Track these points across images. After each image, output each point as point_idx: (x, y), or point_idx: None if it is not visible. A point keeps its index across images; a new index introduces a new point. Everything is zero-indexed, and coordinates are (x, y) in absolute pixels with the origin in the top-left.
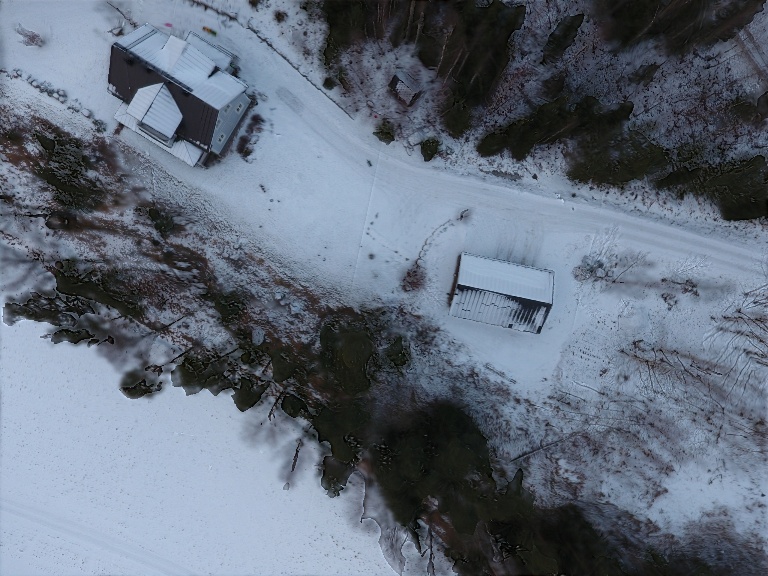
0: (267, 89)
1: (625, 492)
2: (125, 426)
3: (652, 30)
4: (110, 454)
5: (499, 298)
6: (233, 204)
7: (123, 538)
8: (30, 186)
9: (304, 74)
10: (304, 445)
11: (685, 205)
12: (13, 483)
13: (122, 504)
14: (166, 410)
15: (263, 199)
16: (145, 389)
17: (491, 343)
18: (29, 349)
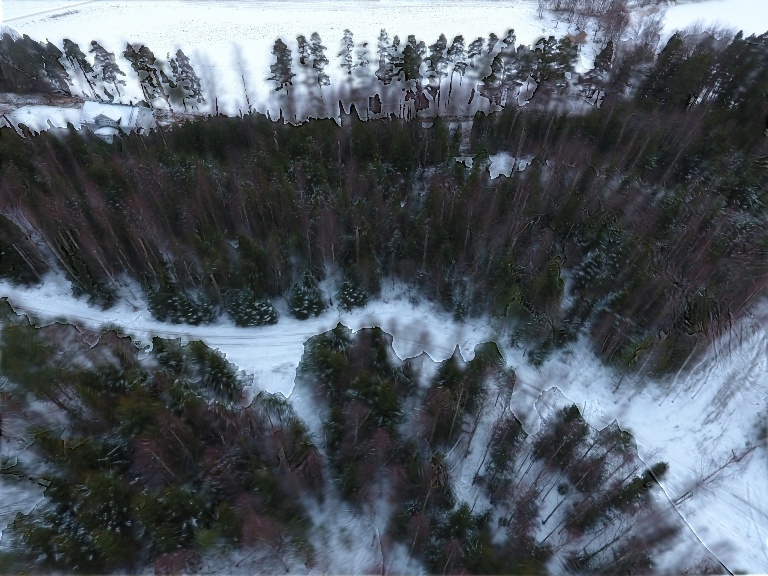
0: None
1: None
2: None
3: None
4: None
5: None
6: None
7: None
8: None
9: None
10: None
11: None
12: None
13: None
14: None
15: None
16: None
17: None
18: None
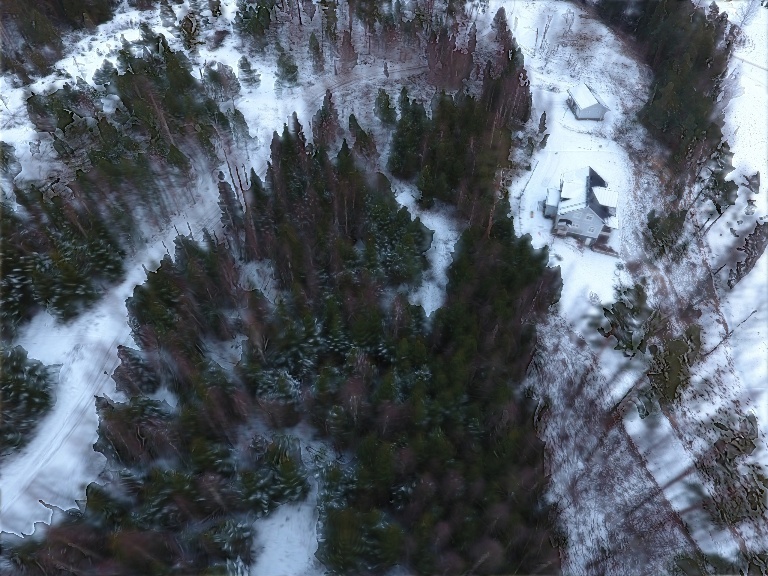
0: None
1: (632, 73)
2: None
3: None
4: None
5: (593, 94)
6: None
7: None
8: None
9: None
10: None
11: None
12: None
13: None
14: None
15: None
16: None
17: None
18: None
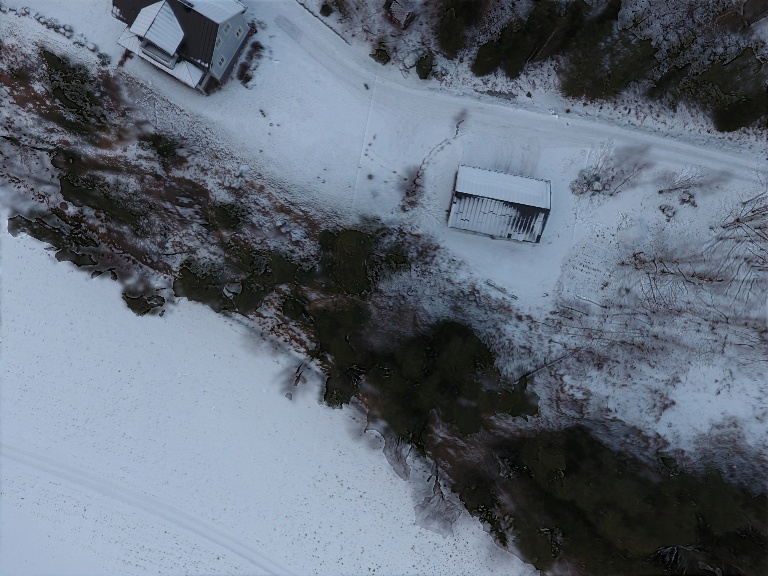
0: (266, 17)
1: (632, 407)
2: (128, 368)
3: None
4: (113, 397)
5: (497, 205)
6: (234, 130)
7: (125, 483)
8: (36, 128)
9: (301, 2)
10: (307, 382)
11: (678, 117)
12: (15, 428)
13: (124, 448)
14: (169, 351)
15: (263, 124)
16: (147, 304)
17: (491, 259)
18: (33, 292)
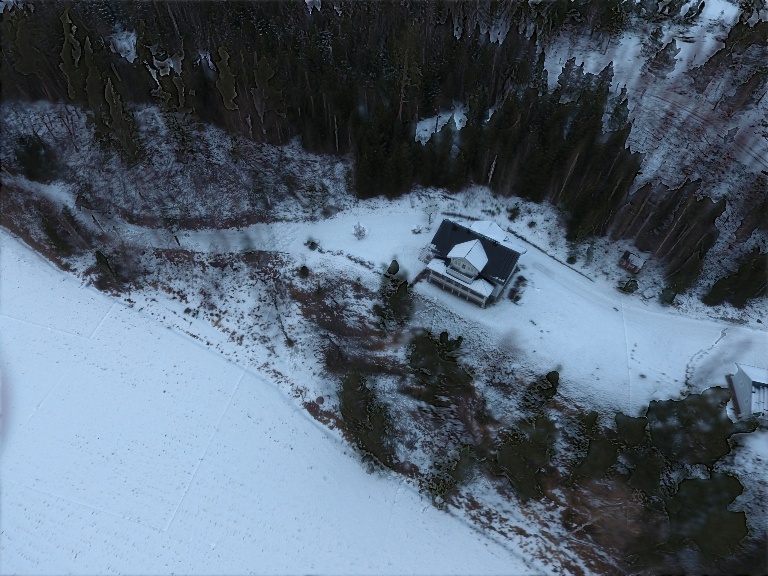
0: (525, 263)
1: None
2: None
3: None
4: None
5: None
6: (508, 334)
7: None
8: (312, 334)
9: (551, 255)
10: None
11: None
12: None
13: None
14: None
15: (534, 330)
16: None
17: None
18: (266, 488)
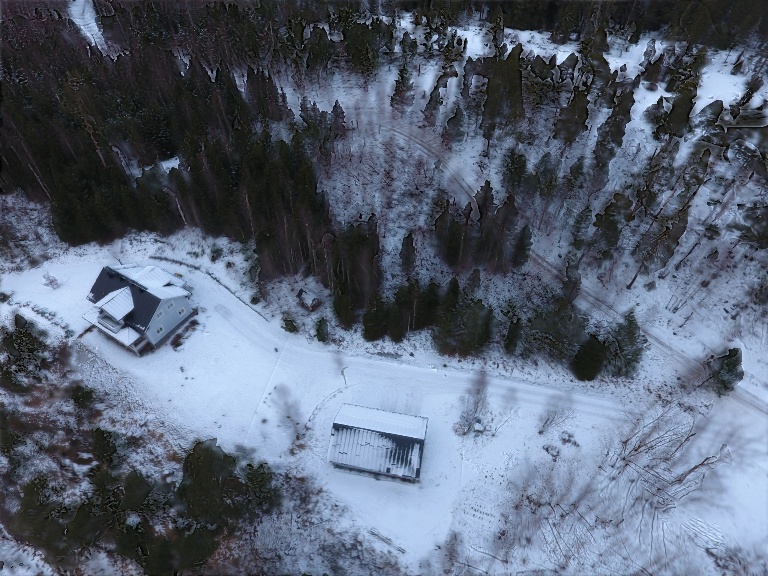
0: (208, 305)
1: None
2: None
3: (474, 256)
4: None
5: (373, 436)
6: (152, 383)
7: None
8: None
9: (238, 296)
10: None
11: (541, 370)
12: None
13: None
14: None
15: (180, 378)
16: None
17: (376, 503)
18: None
